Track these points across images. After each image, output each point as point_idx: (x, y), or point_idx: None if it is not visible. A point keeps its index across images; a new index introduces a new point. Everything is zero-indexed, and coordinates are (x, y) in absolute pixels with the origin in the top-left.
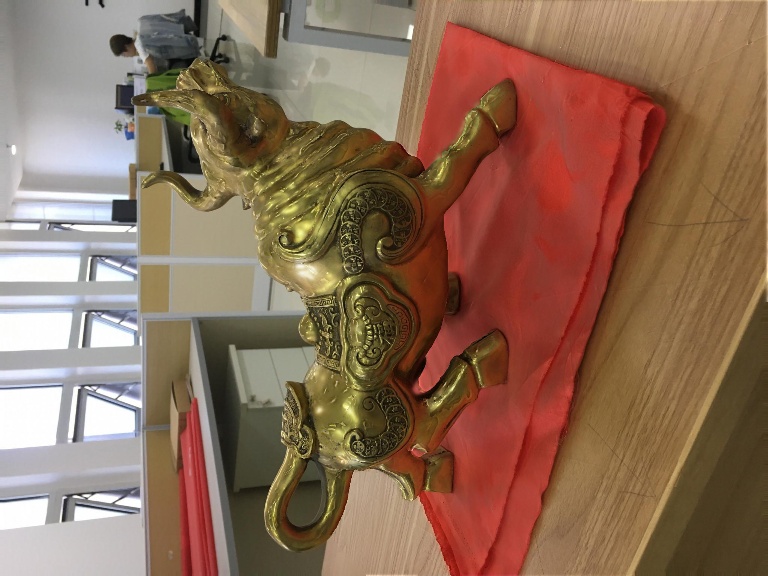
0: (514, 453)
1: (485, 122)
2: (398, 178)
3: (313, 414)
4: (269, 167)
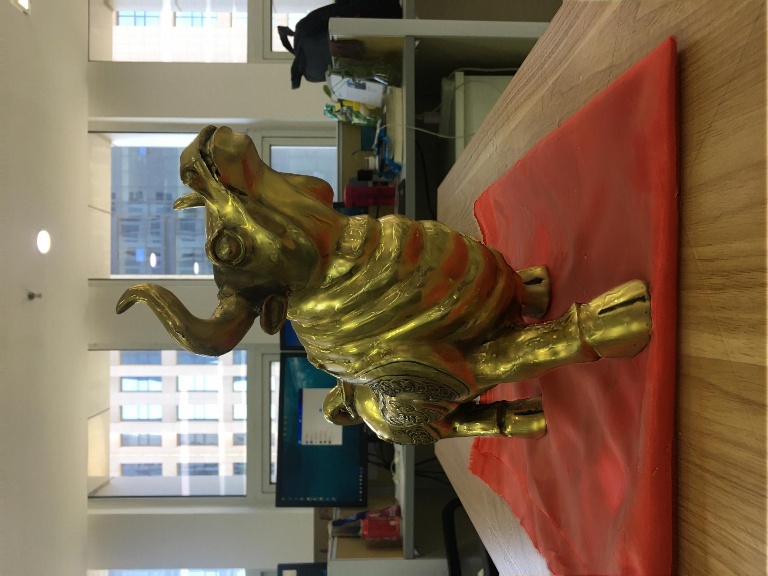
0: (522, 473)
1: (583, 355)
2: (445, 375)
3: (356, 405)
4: (299, 313)
